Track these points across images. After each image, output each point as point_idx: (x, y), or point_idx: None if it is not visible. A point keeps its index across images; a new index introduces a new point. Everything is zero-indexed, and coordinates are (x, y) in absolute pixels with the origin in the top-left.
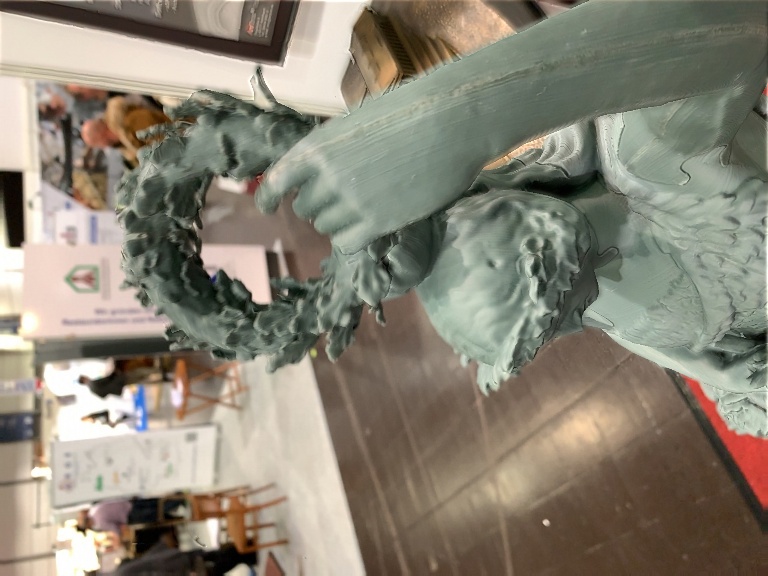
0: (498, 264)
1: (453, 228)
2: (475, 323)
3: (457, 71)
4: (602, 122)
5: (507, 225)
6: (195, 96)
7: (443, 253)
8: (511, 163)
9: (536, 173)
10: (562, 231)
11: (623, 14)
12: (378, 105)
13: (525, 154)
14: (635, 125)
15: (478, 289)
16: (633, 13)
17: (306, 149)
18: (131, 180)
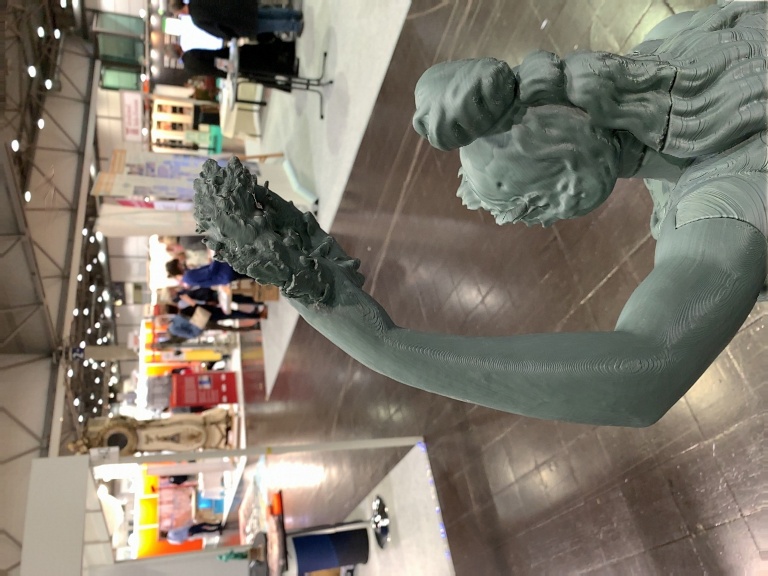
0: (504, 188)
1: (509, 138)
2: (468, 179)
3: (387, 369)
4: (742, 155)
5: (540, 174)
6: (247, 271)
7: (486, 142)
8: (664, 76)
9: (641, 131)
10: (563, 210)
11: (499, 406)
12: (345, 338)
13: (689, 78)
14: (667, 246)
15: (479, 183)
16: (506, 408)
17: (301, 314)
18: (204, 226)
